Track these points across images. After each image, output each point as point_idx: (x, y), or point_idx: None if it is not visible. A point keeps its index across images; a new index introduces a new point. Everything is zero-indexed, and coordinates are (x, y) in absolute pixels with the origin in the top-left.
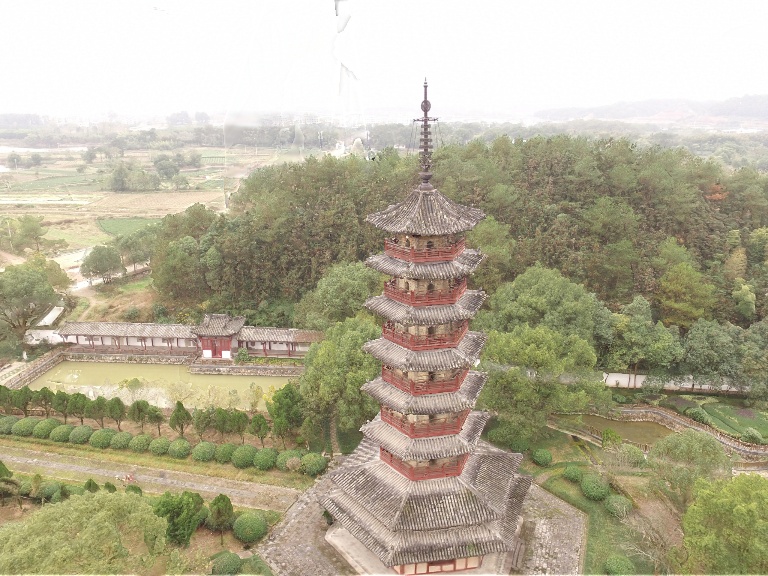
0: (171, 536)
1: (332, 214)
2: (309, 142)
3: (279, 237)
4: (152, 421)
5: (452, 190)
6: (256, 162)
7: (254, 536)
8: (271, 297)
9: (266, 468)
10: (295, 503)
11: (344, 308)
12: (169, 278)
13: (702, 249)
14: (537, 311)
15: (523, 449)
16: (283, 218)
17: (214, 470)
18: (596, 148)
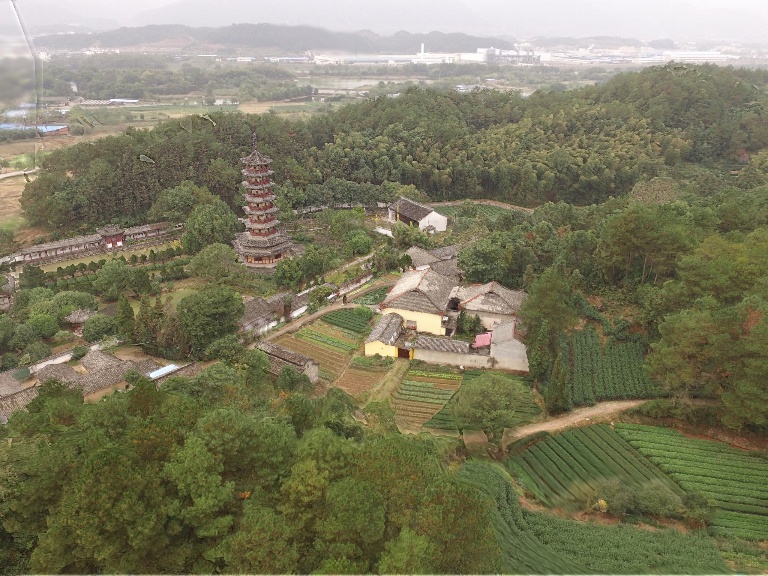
0: None
1: None
2: (17, 122)
3: (113, 184)
4: None
5: (193, 148)
6: None
7: None
8: (116, 216)
9: None
10: None
11: None
12: (60, 216)
13: (297, 159)
14: None
15: None
16: None
17: None
18: (237, 117)
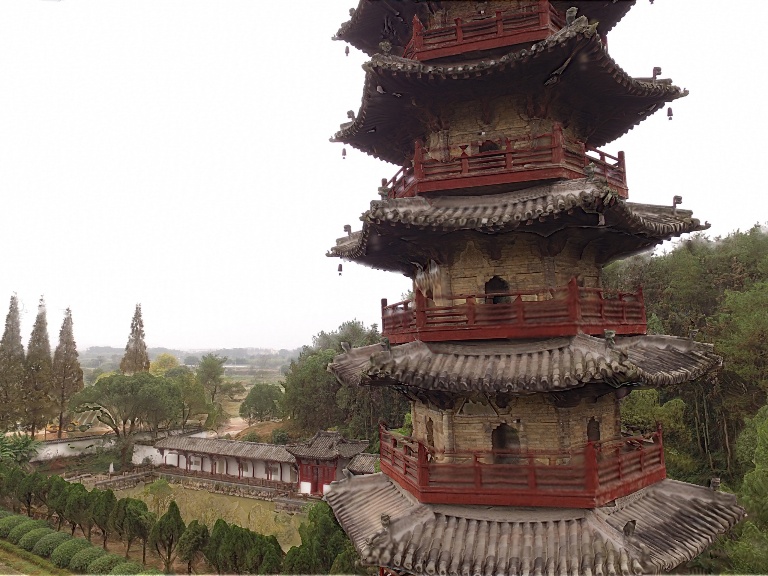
0: None
1: None
2: None
3: None
4: (131, 531)
5: (692, 267)
6: None
7: None
8: None
9: None
10: None
11: None
12: (295, 394)
13: None
14: None
15: None
16: None
17: None
18: None
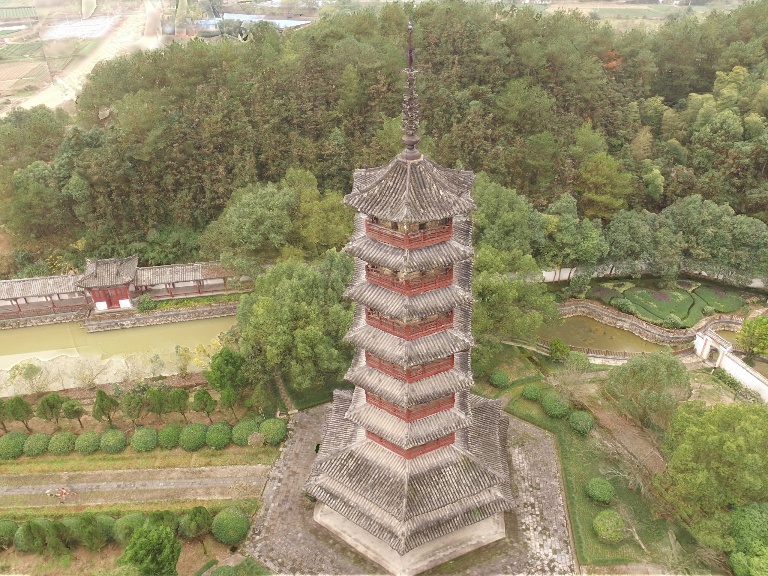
0: (157, 575)
1: (218, 120)
2: None
3: (157, 153)
4: (71, 417)
5: (354, 81)
6: (84, 35)
7: (239, 537)
8: (160, 224)
9: (222, 447)
10: (268, 483)
11: (264, 243)
12: (26, 218)
13: (606, 126)
14: (477, 227)
15: (479, 373)
16: (159, 130)
17: (163, 460)
18: (493, 14)
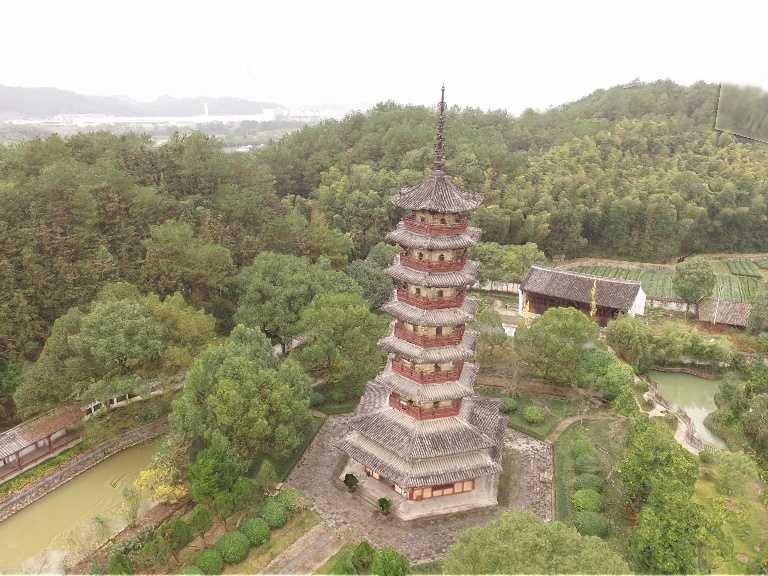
0: None
1: None
2: None
3: None
4: None
5: (94, 201)
6: None
7: None
8: None
9: None
10: None
11: None
12: None
13: None
14: (307, 286)
15: None
16: None
17: None
18: None
